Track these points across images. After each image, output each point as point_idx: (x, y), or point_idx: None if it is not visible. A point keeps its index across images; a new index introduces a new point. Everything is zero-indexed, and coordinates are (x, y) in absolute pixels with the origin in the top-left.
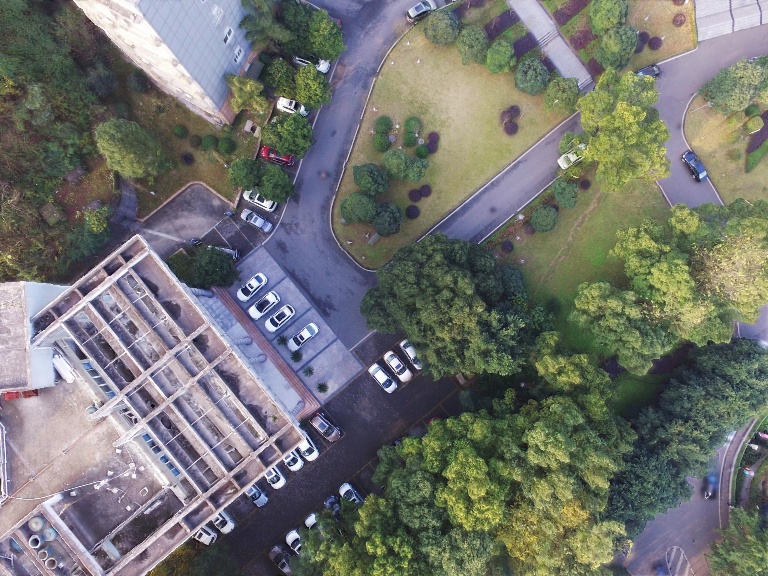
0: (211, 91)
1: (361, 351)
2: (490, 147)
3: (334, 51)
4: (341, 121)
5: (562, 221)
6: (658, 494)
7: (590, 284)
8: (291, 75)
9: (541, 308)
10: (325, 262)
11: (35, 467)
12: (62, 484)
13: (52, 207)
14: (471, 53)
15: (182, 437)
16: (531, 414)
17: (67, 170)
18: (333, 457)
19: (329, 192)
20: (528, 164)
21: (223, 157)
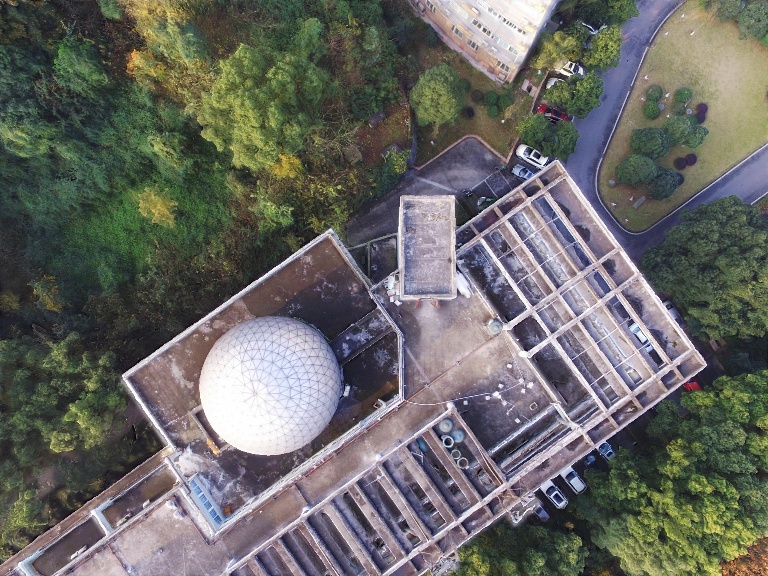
0: None
1: (619, 310)
2: (754, 122)
3: (628, 16)
4: (612, 87)
5: None
6: None
7: None
8: (587, 36)
9: None
10: None
11: (430, 375)
12: (454, 393)
13: None
14: (755, 27)
15: (586, 355)
16: None
17: (371, 112)
18: None
19: (596, 154)
20: None
21: (516, 111)
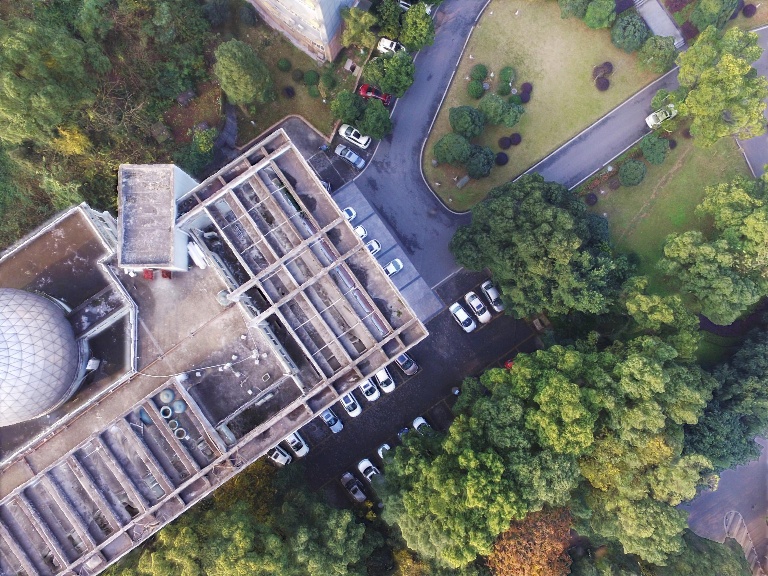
0: (327, 20)
1: (442, 290)
2: (580, 101)
3: None
4: (437, 66)
5: (646, 179)
6: (730, 449)
7: (679, 234)
8: (398, 14)
9: (625, 258)
10: (413, 201)
11: (164, 346)
12: (188, 364)
13: (162, 125)
14: (572, 5)
15: (310, 324)
16: (616, 354)
17: (179, 91)
18: (409, 391)
19: (421, 134)
20: (616, 121)
21: (327, 89)
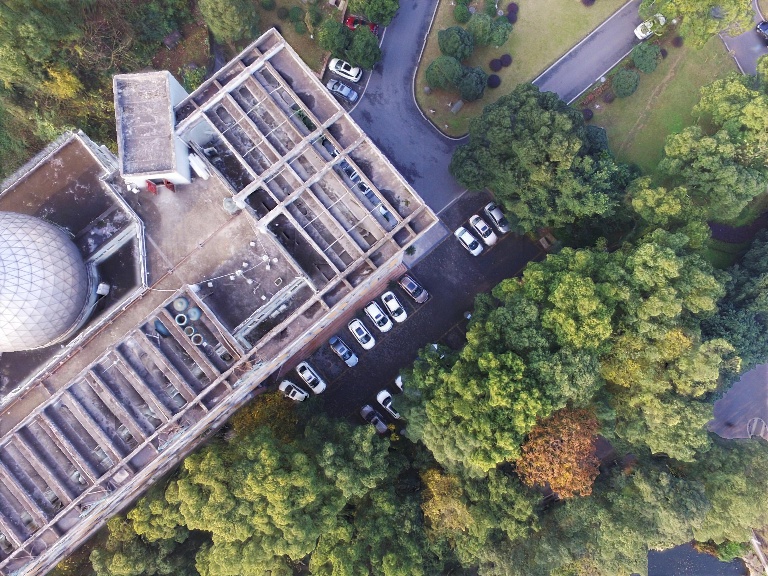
0: None
1: (446, 216)
2: (568, 18)
3: None
4: None
5: (640, 90)
6: (748, 346)
7: (679, 133)
8: None
9: (626, 165)
10: (409, 131)
11: (173, 260)
12: (199, 276)
13: (151, 70)
14: None
15: (318, 221)
16: None
17: (166, 33)
18: (421, 319)
19: (411, 63)
20: (605, 35)
21: (314, 20)
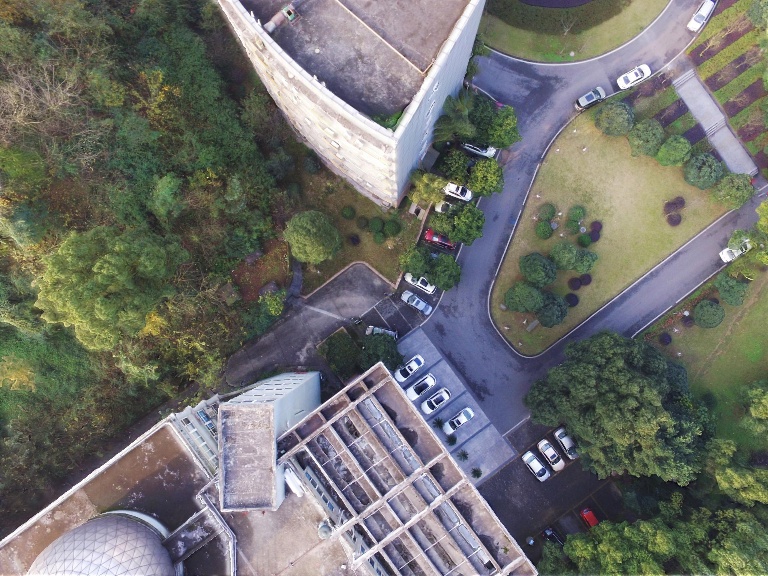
0: (400, 186)
1: (514, 437)
2: (652, 237)
3: (510, 142)
4: (503, 206)
5: None
6: None
7: (766, 392)
8: (467, 166)
9: (706, 409)
10: (481, 346)
11: None
12: None
13: (230, 287)
14: (645, 147)
15: (414, 562)
16: (704, 524)
17: (247, 252)
18: None
19: (488, 276)
20: (688, 255)
21: (396, 244)
